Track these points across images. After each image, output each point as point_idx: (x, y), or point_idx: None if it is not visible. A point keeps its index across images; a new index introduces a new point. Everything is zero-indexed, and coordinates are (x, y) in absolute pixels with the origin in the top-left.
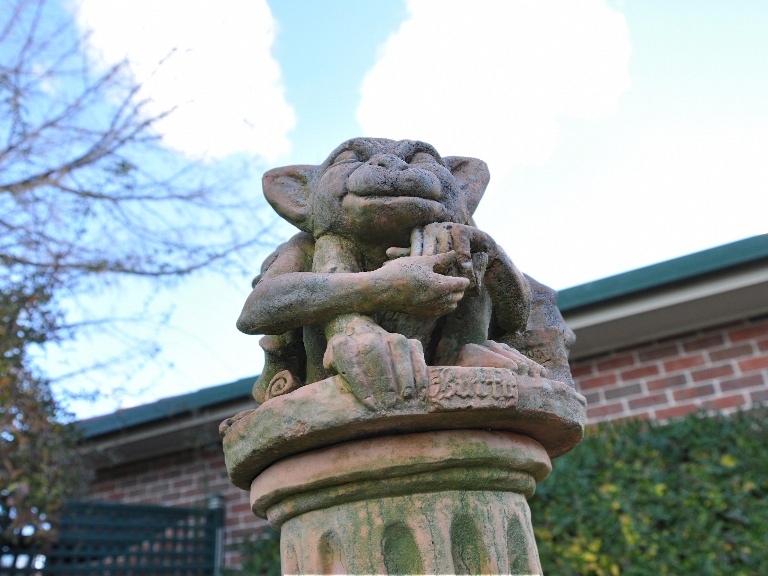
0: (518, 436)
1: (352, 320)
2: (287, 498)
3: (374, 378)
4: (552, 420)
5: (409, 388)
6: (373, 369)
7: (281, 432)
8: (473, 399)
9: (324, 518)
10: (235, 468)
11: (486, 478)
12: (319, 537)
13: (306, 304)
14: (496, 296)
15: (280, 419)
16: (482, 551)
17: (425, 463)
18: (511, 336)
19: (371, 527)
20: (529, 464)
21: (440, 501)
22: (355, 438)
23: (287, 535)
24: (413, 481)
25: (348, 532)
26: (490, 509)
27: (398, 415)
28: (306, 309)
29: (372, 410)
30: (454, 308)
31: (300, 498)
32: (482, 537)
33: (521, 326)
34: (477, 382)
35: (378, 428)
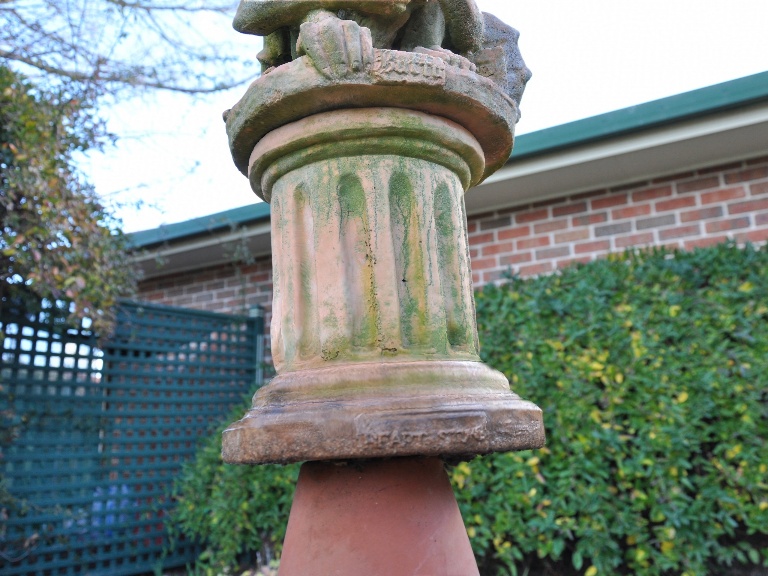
0: (451, 121)
1: (319, 13)
2: (272, 163)
3: (330, 53)
4: (478, 108)
5: (357, 62)
6: (330, 45)
7: (263, 100)
8: (408, 75)
9: (298, 174)
10: (234, 142)
11: (421, 148)
12: (294, 188)
13: (283, 1)
14: (448, 13)
15: (263, 91)
16: (413, 199)
17: (371, 128)
18: (464, 55)
19: (331, 177)
20: (458, 144)
21: (383, 161)
22: (321, 111)
23: (274, 194)
24: (363, 143)
25: (314, 181)
26: (423, 172)
27: (348, 84)
28: (284, 5)
29: (329, 78)
30: (403, 9)
31: (281, 161)
32: (414, 189)
33: (473, 47)
34: (412, 63)
35: (337, 100)
